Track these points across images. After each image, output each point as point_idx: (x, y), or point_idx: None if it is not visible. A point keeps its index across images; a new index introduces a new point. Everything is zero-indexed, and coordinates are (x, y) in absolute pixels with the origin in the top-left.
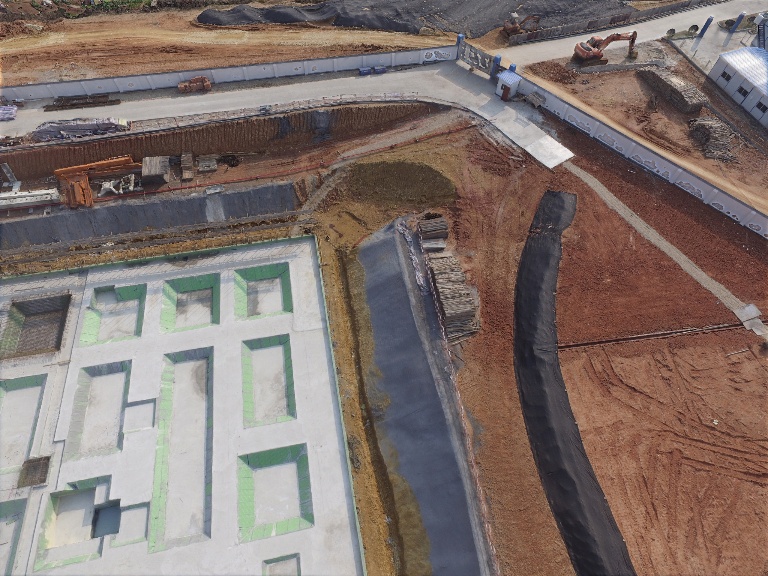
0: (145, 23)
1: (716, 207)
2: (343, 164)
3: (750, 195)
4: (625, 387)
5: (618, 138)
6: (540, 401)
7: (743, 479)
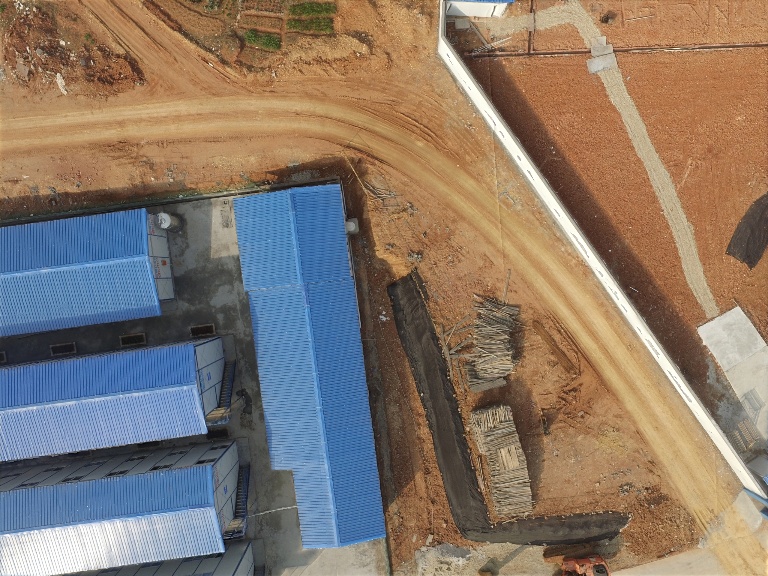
0: None
1: (554, 217)
2: None
3: (494, 236)
4: None
5: None
6: None
7: None
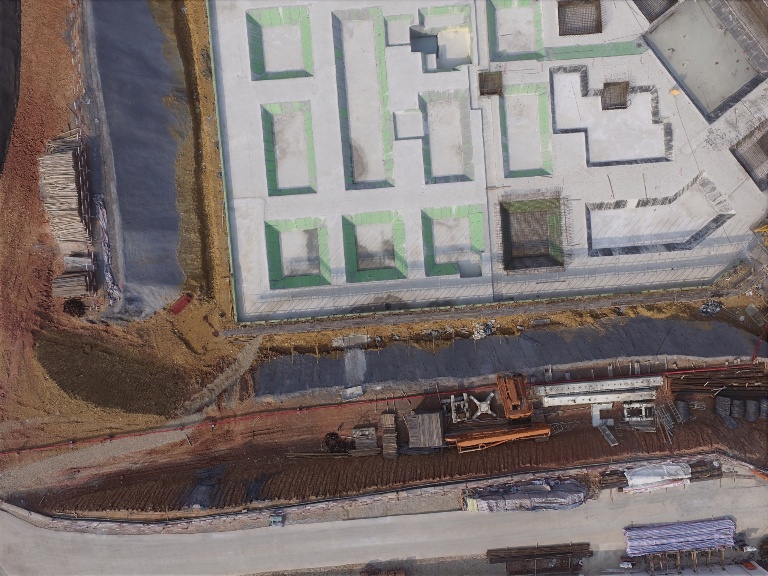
0: None
1: None
2: (185, 419)
3: None
4: None
5: None
6: None
7: None
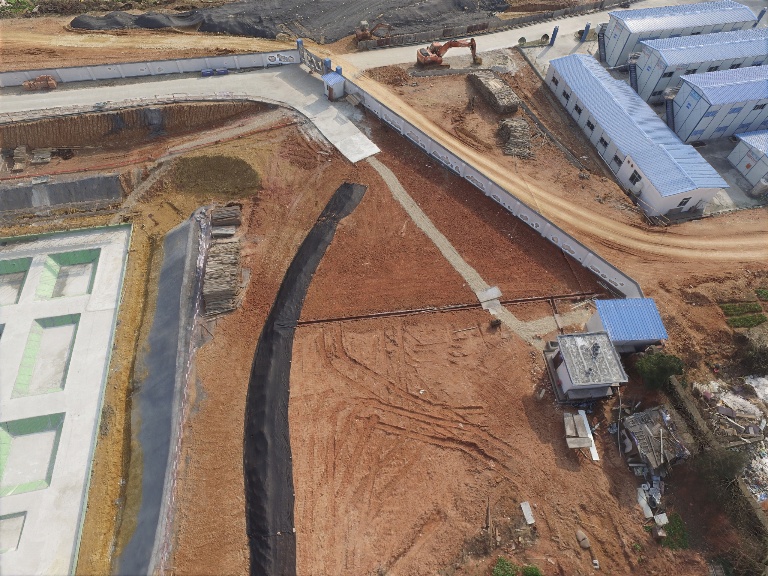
0: (20, 27)
1: (496, 199)
2: (169, 158)
3: (534, 189)
4: (348, 359)
5: (419, 135)
6: (264, 371)
7: (428, 442)
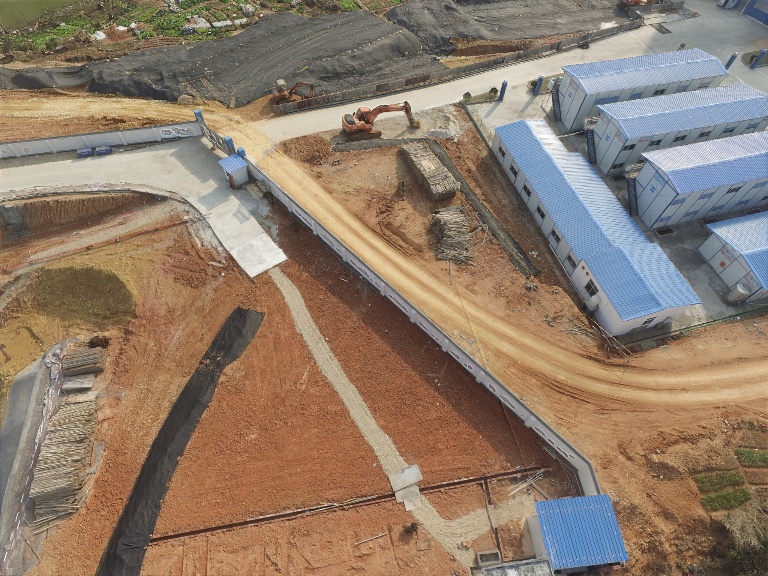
0: None
1: (424, 326)
2: (28, 269)
3: (471, 308)
4: None
5: (332, 240)
6: None
7: None
